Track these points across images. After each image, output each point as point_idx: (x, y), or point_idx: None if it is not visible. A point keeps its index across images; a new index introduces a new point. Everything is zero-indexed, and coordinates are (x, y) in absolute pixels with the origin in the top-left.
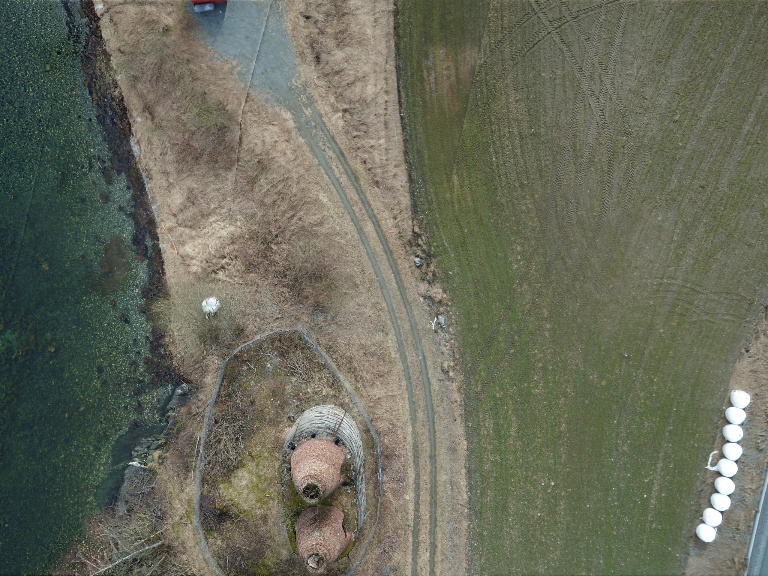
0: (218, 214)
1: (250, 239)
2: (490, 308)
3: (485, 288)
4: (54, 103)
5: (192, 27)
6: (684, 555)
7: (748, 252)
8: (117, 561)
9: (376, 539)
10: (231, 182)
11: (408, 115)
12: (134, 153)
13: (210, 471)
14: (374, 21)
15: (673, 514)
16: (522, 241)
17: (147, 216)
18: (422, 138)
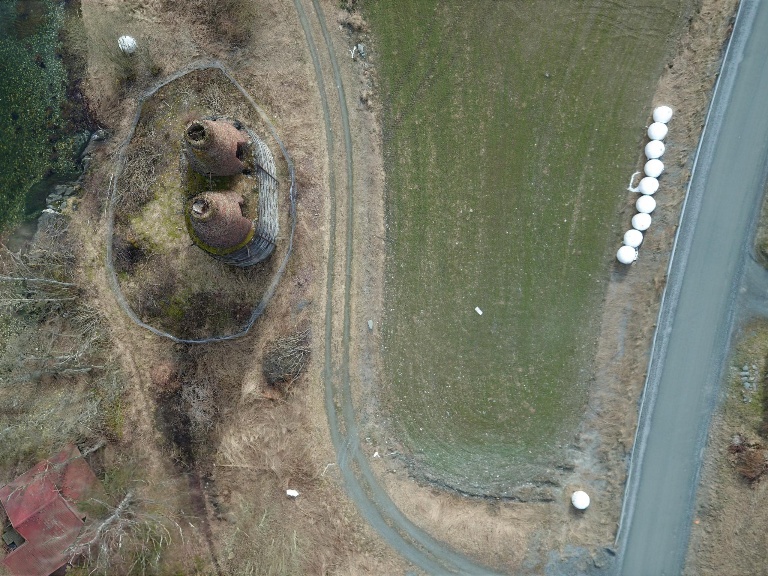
0: None
1: None
2: (410, 33)
3: (405, 13)
4: None
5: None
6: (604, 281)
7: None
8: (18, 278)
9: (290, 270)
10: None
11: None
12: None
13: (122, 207)
14: None
15: (593, 238)
16: None
17: None
18: None
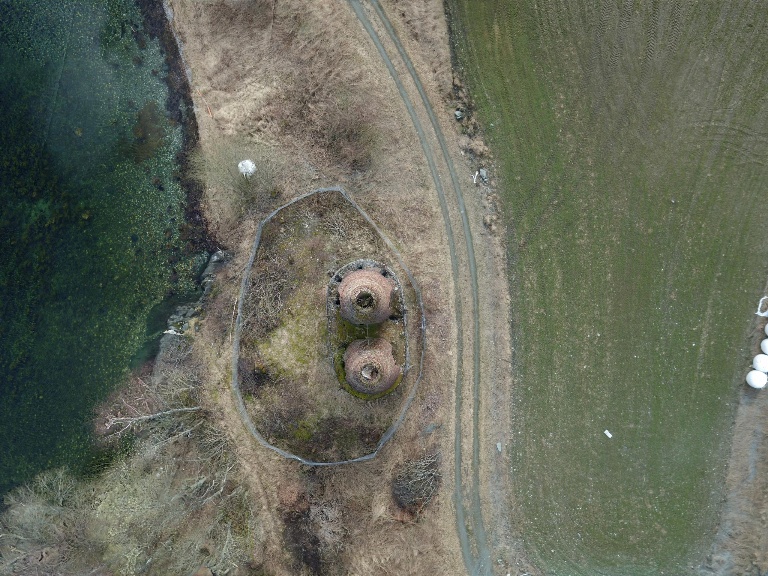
0: (253, 75)
1: (286, 99)
2: (533, 159)
3: (528, 139)
4: None
5: None
6: (734, 404)
7: None
8: (157, 413)
9: (419, 395)
10: (267, 41)
11: None
12: (167, 16)
13: (248, 332)
14: None
15: (722, 362)
16: (565, 89)
17: (181, 81)
18: None
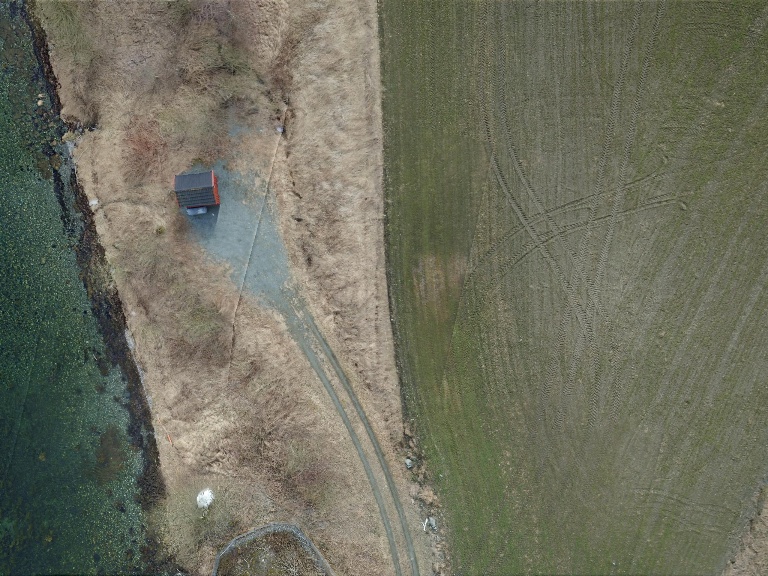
0: (212, 409)
1: (244, 434)
2: (480, 512)
3: (475, 492)
4: (50, 295)
5: (185, 230)
6: None
7: (733, 466)
8: None
9: None
10: (225, 379)
11: (398, 321)
12: (129, 346)
13: None
14: (364, 229)
15: None
16: (511, 447)
17: (142, 407)
18: (412, 343)
